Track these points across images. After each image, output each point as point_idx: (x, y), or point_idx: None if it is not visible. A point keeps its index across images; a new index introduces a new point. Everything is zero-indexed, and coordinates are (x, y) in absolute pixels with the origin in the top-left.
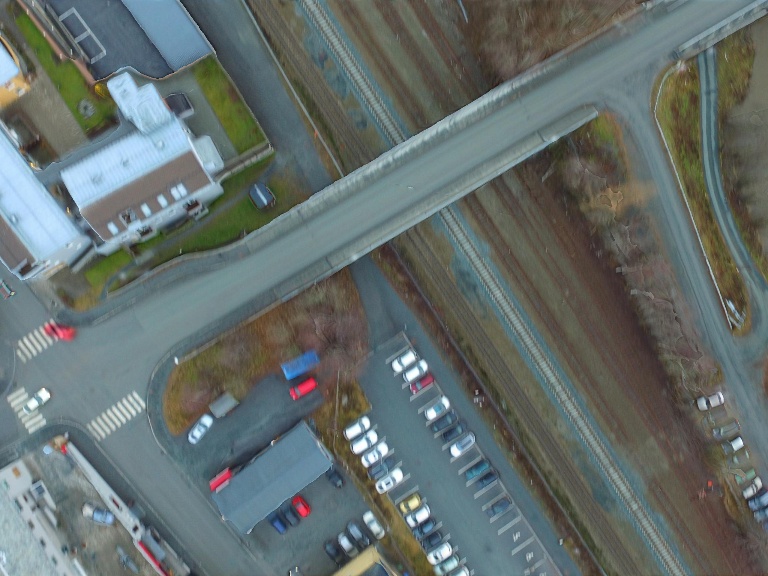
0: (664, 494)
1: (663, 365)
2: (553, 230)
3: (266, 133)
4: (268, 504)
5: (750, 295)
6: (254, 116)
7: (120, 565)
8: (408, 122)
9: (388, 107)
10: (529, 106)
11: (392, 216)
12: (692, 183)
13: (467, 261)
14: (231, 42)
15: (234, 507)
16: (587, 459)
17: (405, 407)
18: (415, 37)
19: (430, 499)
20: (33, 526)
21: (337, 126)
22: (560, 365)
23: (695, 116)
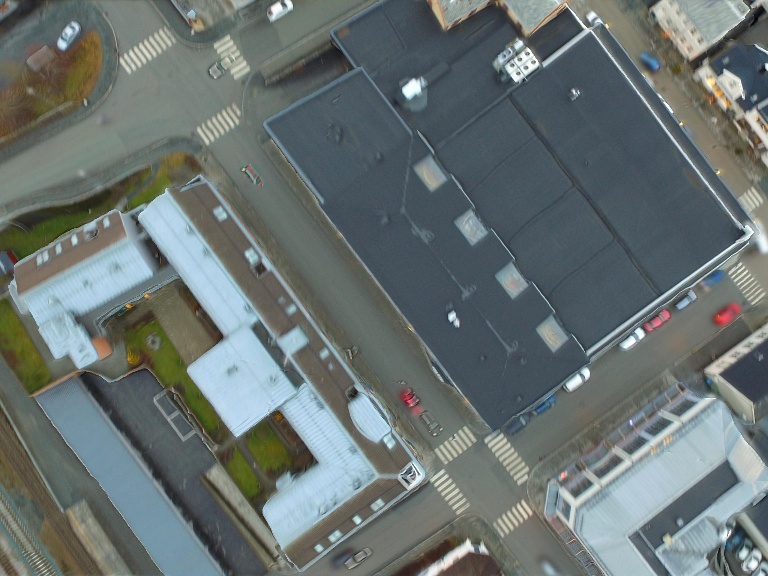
0: None
1: None
2: None
3: None
4: None
5: None
6: None
7: None
8: None
9: None
10: None
11: None
12: None
13: None
14: (45, 415)
15: None
16: None
17: None
18: None
19: None
20: None
21: None
22: None
23: None
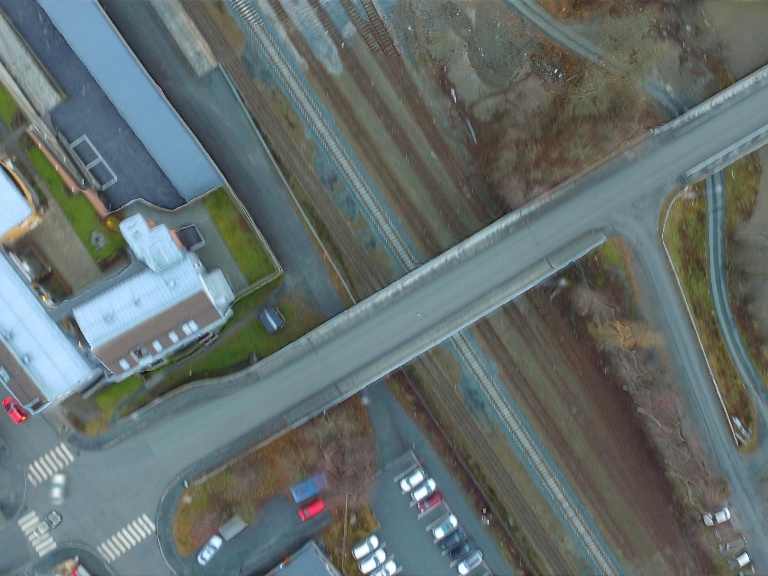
0: None
1: (670, 481)
2: (561, 348)
3: (276, 254)
4: None
5: (756, 411)
6: (264, 238)
7: None
8: (417, 242)
9: (397, 228)
10: (537, 232)
11: (401, 343)
12: (699, 302)
13: (475, 379)
14: (241, 165)
15: None
16: (594, 575)
17: (413, 525)
18: (424, 158)
19: None
20: None
21: (346, 247)
22: (567, 482)
23: (702, 234)
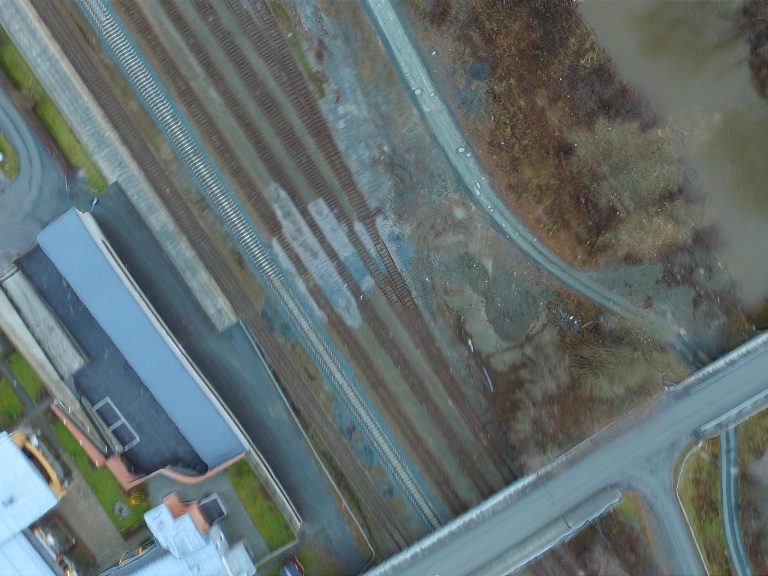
0: None
1: None
2: None
3: (295, 504)
4: None
5: None
6: (283, 489)
7: None
8: (434, 489)
9: (414, 475)
10: (554, 491)
11: None
12: (712, 545)
13: None
14: (261, 417)
15: None
16: None
17: None
18: (441, 406)
19: None
20: None
21: (364, 496)
22: None
23: (715, 475)
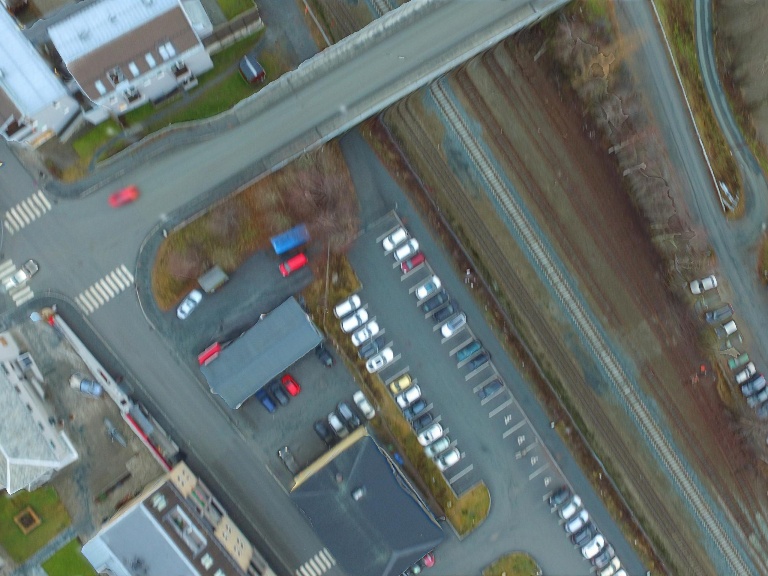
0: (657, 378)
1: (656, 248)
2: (545, 110)
3: None
4: (257, 378)
5: (744, 179)
6: None
7: (108, 438)
8: None
9: None
10: None
11: (383, 86)
12: (685, 63)
13: (459, 140)
14: None
15: (223, 379)
16: (579, 342)
17: (396, 287)
18: None
19: (421, 380)
20: (19, 391)
21: (328, 2)
22: (552, 247)
23: None
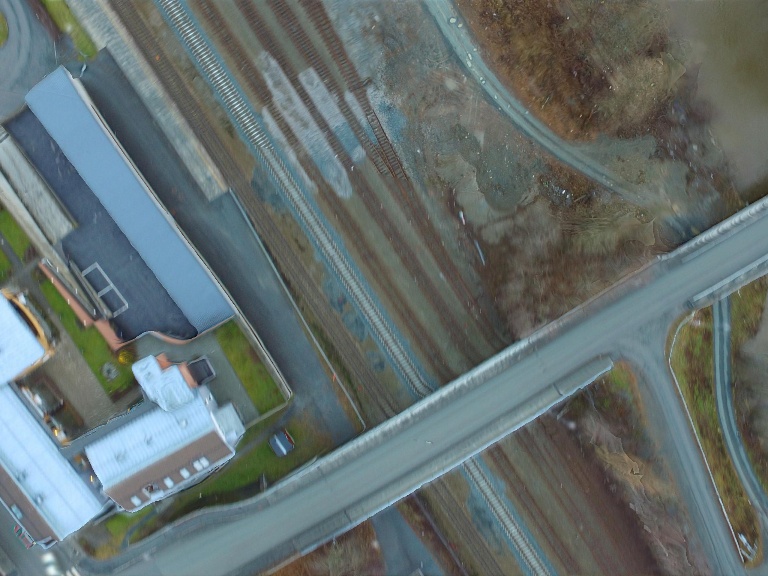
0: None
1: None
2: (568, 466)
3: (285, 376)
4: None
5: (762, 526)
6: (273, 360)
7: None
8: (425, 363)
9: (405, 348)
10: (545, 359)
11: (410, 470)
12: (705, 421)
13: (483, 498)
14: (251, 288)
15: None
16: None
17: None
18: (432, 279)
19: None
20: None
21: (355, 368)
22: None
23: (708, 352)
